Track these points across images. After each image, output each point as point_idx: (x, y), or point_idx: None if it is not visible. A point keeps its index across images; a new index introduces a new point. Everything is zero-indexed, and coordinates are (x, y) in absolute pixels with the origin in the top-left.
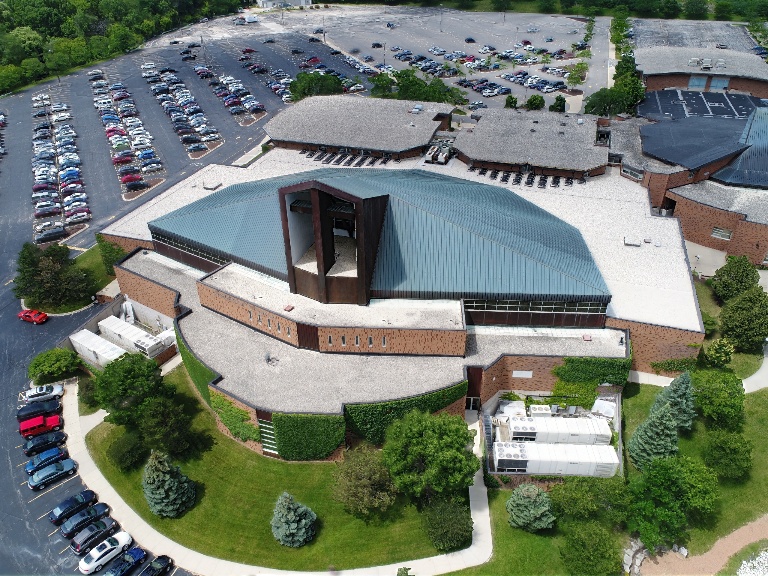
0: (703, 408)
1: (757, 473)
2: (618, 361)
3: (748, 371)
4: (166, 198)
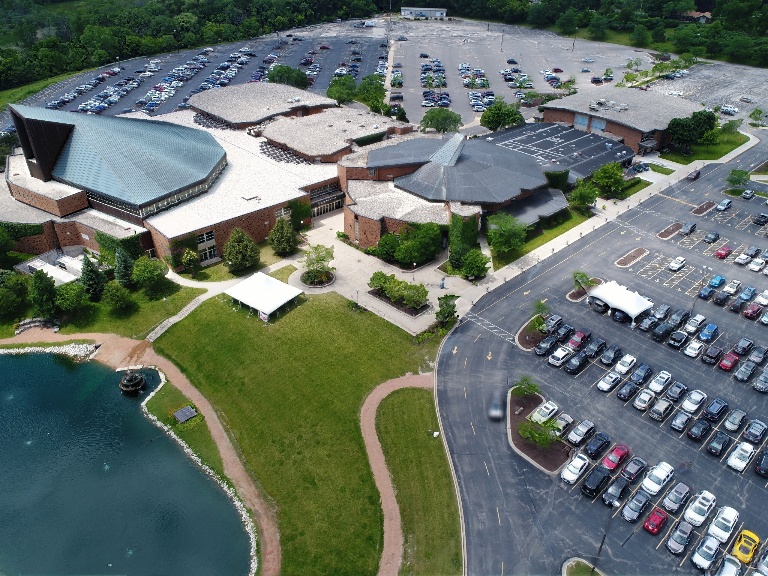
0: (132, 275)
1: (135, 318)
2: (114, 239)
3: (214, 280)
4: None
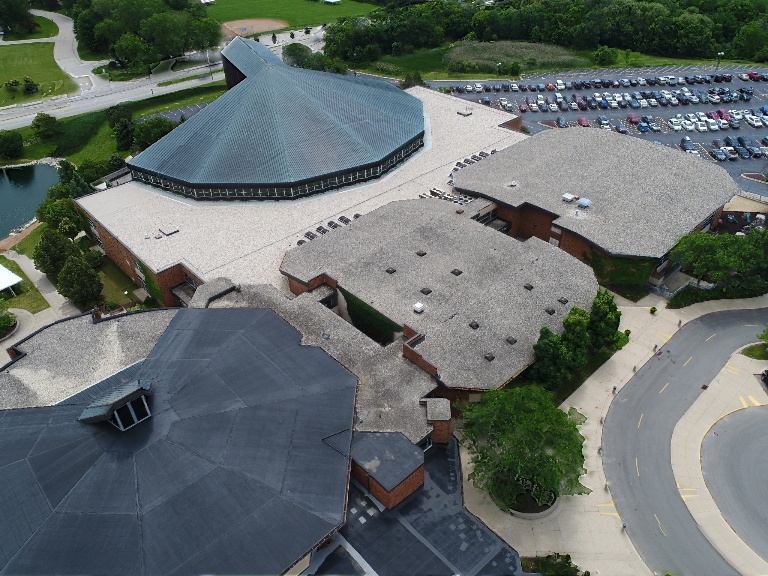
0: None
1: None
2: None
3: None
4: (455, 101)
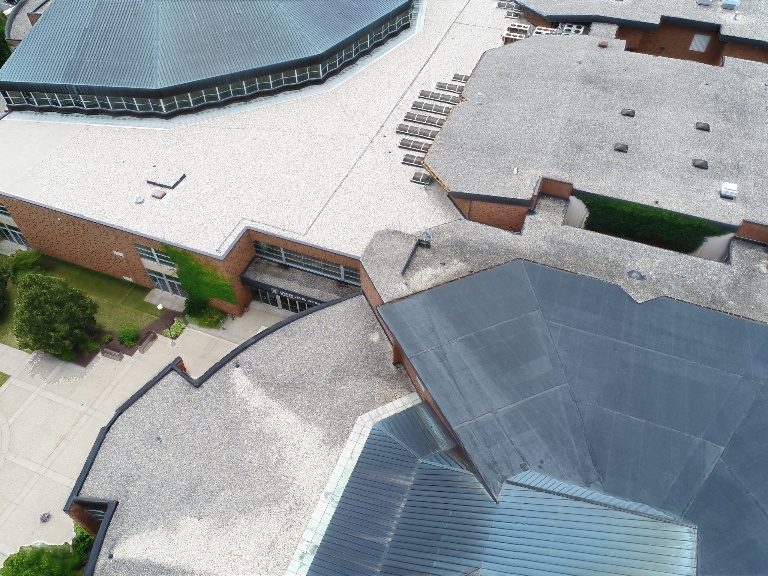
0: None
1: None
2: None
3: None
4: None
